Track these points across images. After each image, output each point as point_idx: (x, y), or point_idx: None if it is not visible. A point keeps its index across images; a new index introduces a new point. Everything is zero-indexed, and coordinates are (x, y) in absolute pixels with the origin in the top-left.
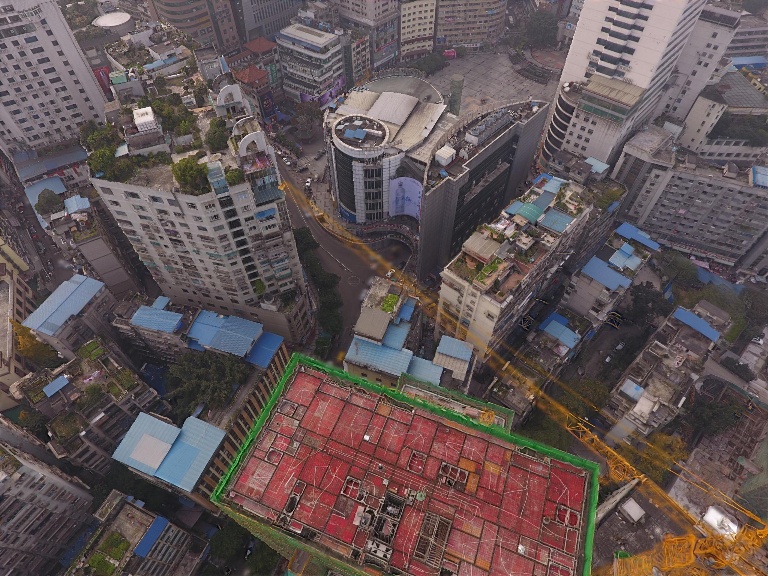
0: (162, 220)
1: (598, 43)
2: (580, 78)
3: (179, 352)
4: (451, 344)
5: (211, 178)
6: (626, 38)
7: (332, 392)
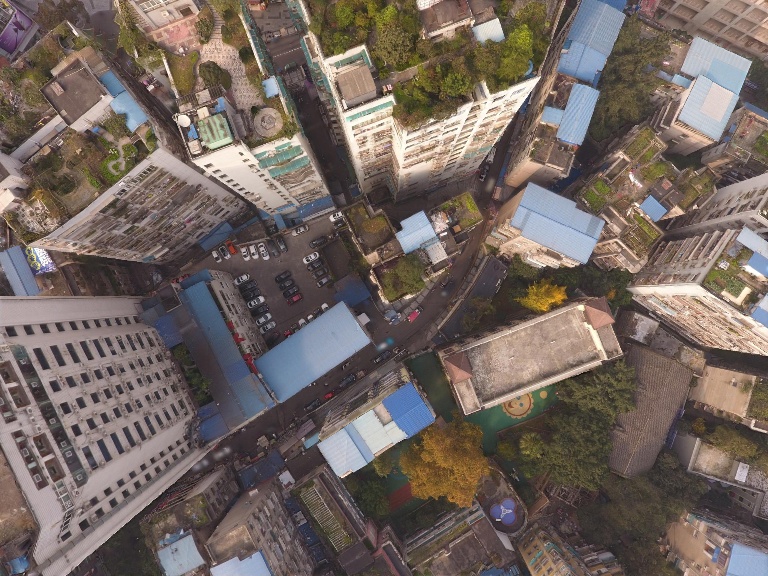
0: None
1: None
2: None
3: None
4: None
5: None
6: None
7: None
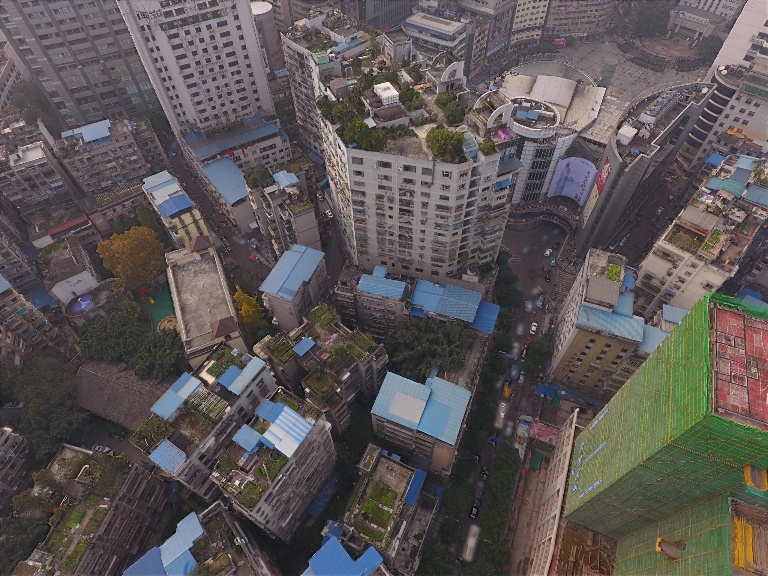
0: (401, 190)
1: (766, 25)
2: (738, 61)
3: (391, 320)
4: (675, 312)
5: (466, 148)
6: None
7: (759, 326)
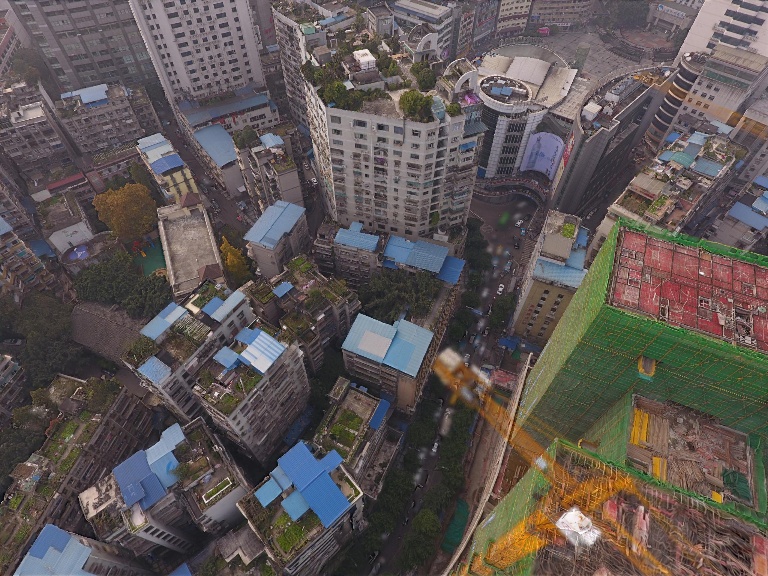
0: (376, 149)
1: (726, 14)
2: (701, 48)
3: (366, 273)
4: None
5: (434, 109)
6: (758, 9)
7: (658, 245)
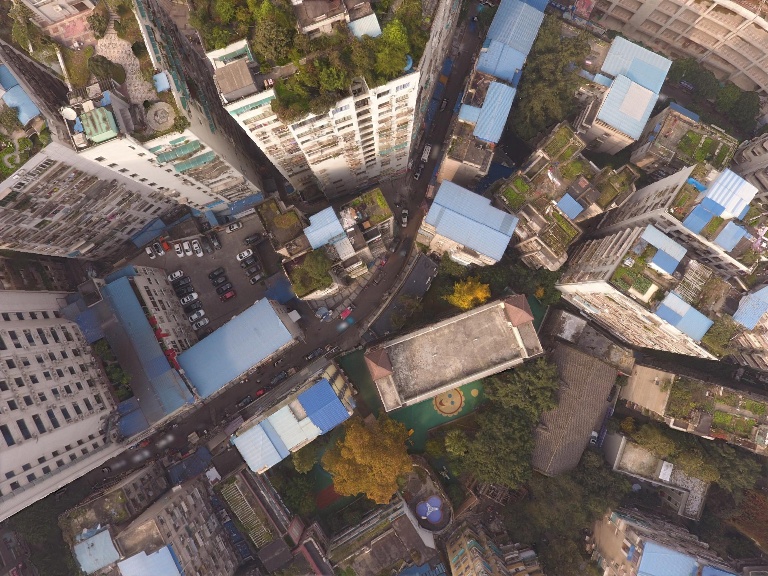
0: None
1: None
2: None
3: None
4: None
5: None
6: None
7: None
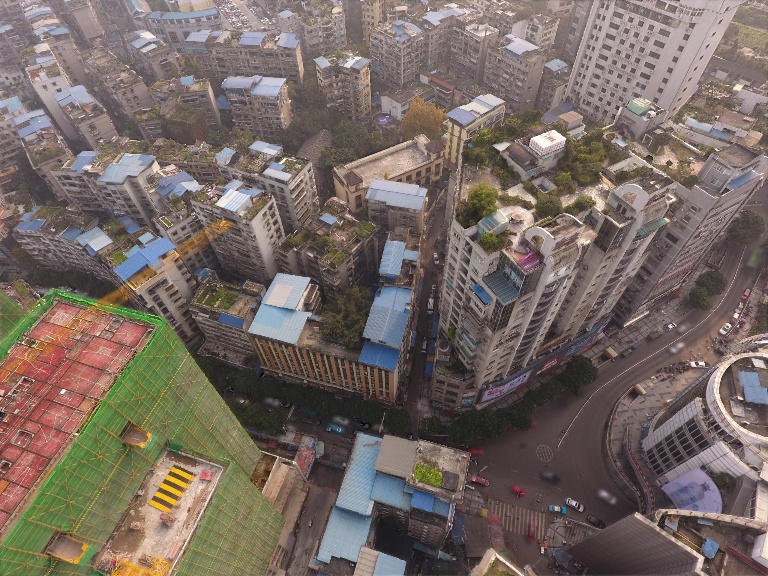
0: None
1: None
2: None
3: None
4: (392, 574)
5: (483, 222)
6: None
7: (119, 357)
